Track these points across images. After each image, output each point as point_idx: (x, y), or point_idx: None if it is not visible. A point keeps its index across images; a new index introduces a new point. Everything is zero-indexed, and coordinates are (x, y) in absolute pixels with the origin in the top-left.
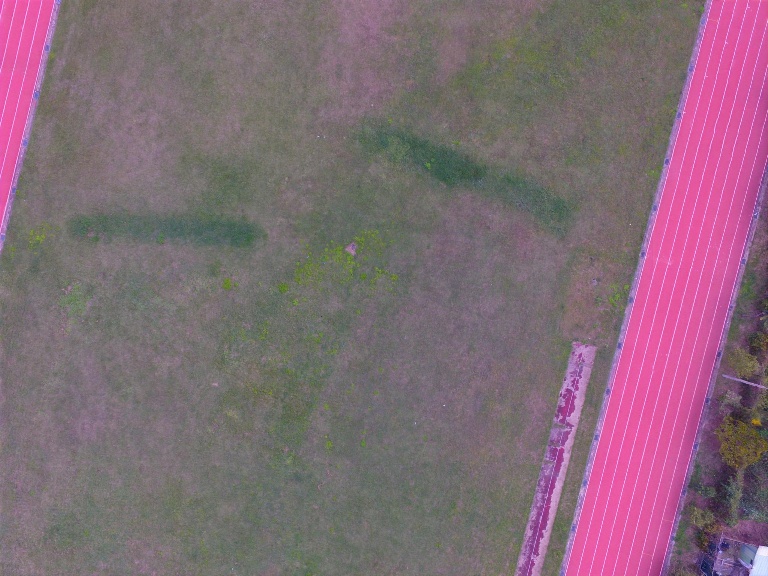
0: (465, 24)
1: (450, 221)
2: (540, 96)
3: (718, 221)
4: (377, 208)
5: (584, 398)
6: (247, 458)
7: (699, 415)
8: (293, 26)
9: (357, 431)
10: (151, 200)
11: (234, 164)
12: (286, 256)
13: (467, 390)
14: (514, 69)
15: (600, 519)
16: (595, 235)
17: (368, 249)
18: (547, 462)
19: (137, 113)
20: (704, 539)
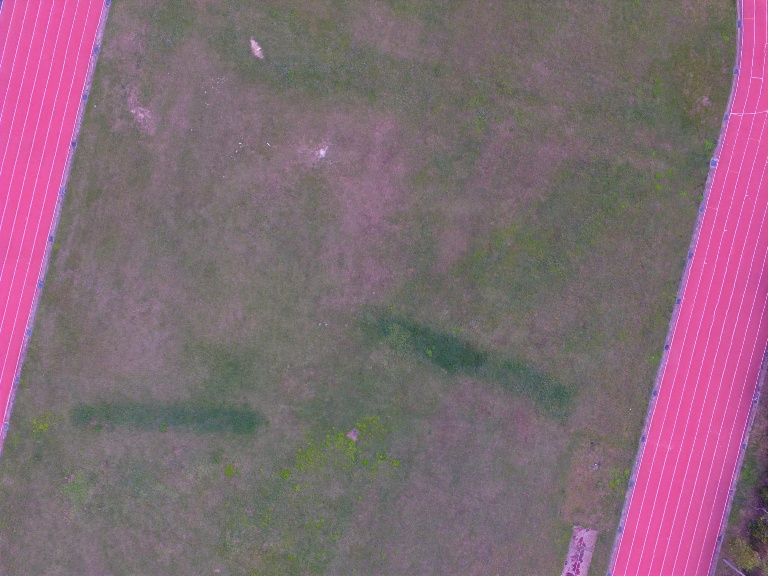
0: (466, 212)
1: (451, 407)
2: (540, 283)
3: (718, 406)
4: (378, 394)
5: None
6: None
7: None
8: (295, 216)
9: None
10: (154, 388)
11: (236, 352)
12: (288, 443)
13: (468, 575)
14: (514, 257)
15: None
16: (596, 420)
17: (370, 435)
18: None
19: (140, 302)
20: None
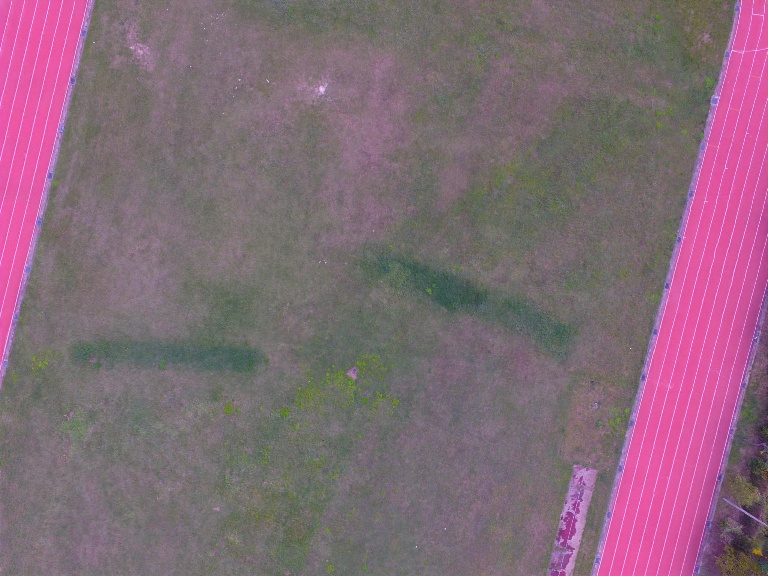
0: (466, 150)
1: (451, 345)
2: (541, 221)
3: (718, 345)
4: (378, 333)
5: (585, 521)
6: None
7: (700, 538)
8: (295, 153)
9: (358, 555)
10: (153, 326)
11: (236, 290)
12: (287, 381)
13: (468, 513)
14: (515, 195)
15: None
16: (596, 359)
17: (369, 373)
18: None
19: (139, 240)
20: None
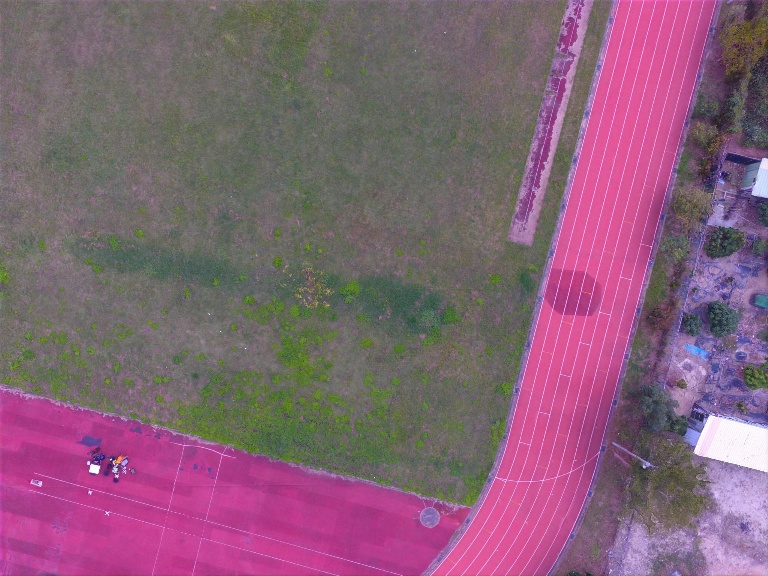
0: None
1: None
2: None
3: None
4: None
5: (587, 27)
6: (245, 84)
7: (703, 44)
8: None
9: (357, 58)
10: None
11: None
12: None
13: (468, 17)
14: None
15: (602, 151)
16: None
17: None
18: (549, 92)
19: None
20: (707, 162)
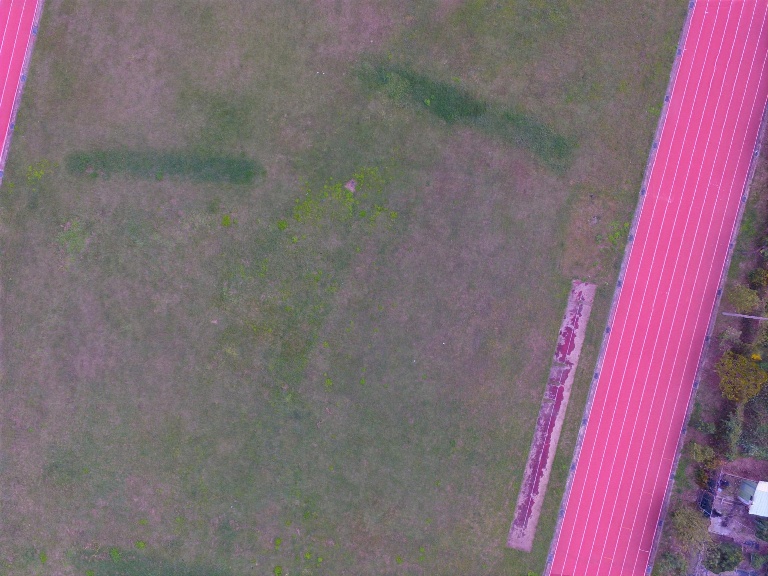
0: None
1: (450, 158)
2: (540, 32)
3: (718, 158)
4: (376, 145)
5: (584, 336)
6: (246, 396)
7: (699, 353)
8: None
9: (356, 369)
10: (150, 136)
11: (233, 100)
12: (285, 193)
13: (467, 328)
14: (514, 5)
15: (600, 457)
16: (595, 173)
17: (367, 186)
18: (547, 400)
19: (136, 49)
20: (704, 476)
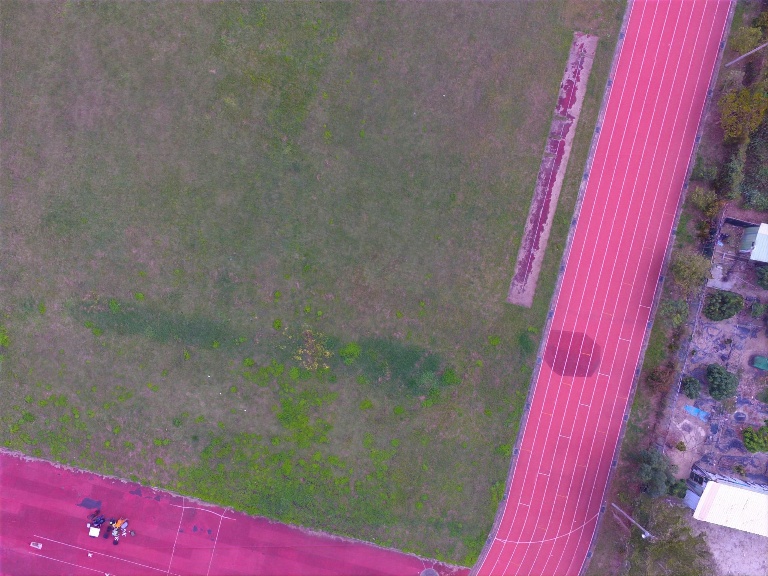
0: None
1: None
2: None
3: None
4: None
5: (585, 89)
6: (245, 147)
7: (701, 107)
8: None
9: (356, 121)
10: None
11: None
12: None
13: (467, 80)
14: None
15: (601, 212)
16: None
17: None
18: (548, 155)
19: None
20: (705, 225)
